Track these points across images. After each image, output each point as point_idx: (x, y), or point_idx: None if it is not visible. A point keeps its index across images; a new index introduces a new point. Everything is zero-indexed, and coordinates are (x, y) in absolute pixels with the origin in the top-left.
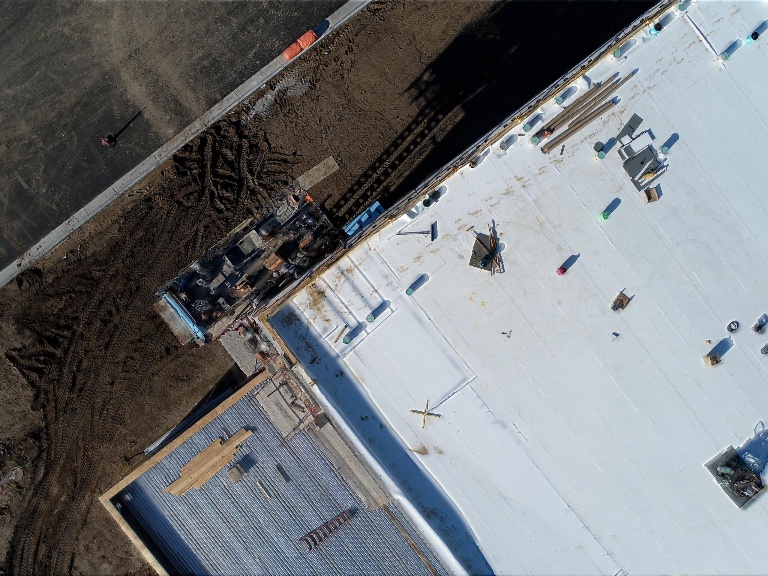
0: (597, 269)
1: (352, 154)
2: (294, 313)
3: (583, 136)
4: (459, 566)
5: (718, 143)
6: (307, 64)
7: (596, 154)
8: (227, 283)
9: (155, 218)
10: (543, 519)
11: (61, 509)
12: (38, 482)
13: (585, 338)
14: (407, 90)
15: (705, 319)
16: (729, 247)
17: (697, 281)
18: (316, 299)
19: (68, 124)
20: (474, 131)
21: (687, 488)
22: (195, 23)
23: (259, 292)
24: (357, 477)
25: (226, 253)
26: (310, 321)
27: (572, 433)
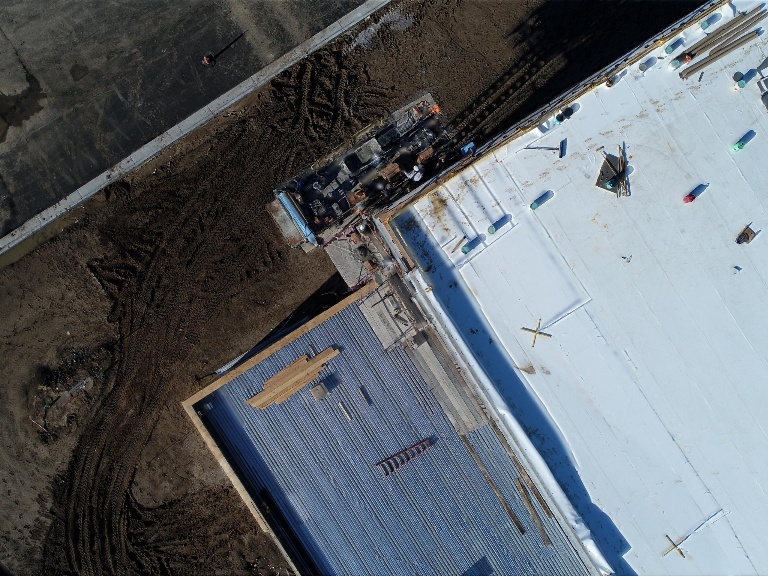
0: (725, 200)
1: (450, 93)
2: (414, 219)
3: (723, 65)
4: (559, 488)
5: None
6: None
7: (735, 83)
8: (340, 190)
9: (248, 141)
10: (646, 450)
11: (127, 423)
12: (107, 394)
13: (706, 270)
14: (511, 34)
15: None
16: None
17: None
18: (437, 207)
19: (170, 40)
20: (575, 80)
21: None
22: None
23: (369, 204)
24: (449, 400)
25: (344, 159)
26: (429, 229)
27: (684, 365)
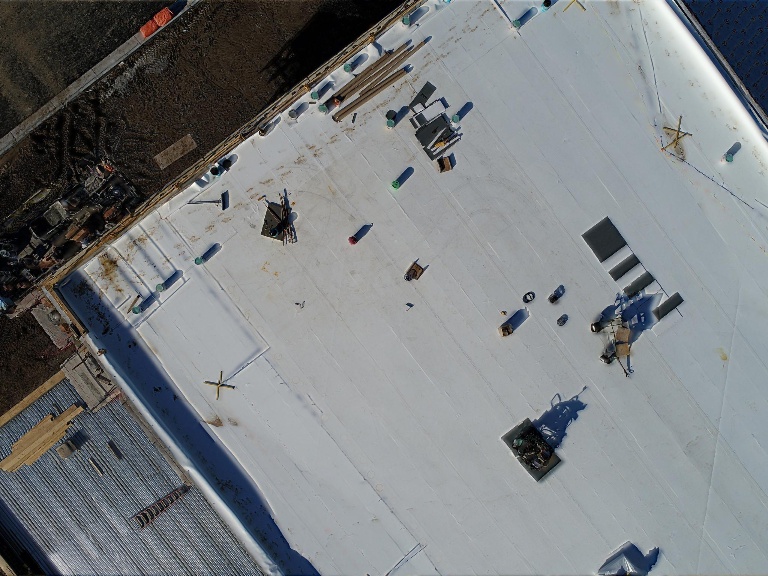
0: (390, 239)
1: (210, 132)
2: (86, 283)
3: (375, 104)
4: (250, 539)
5: (513, 112)
6: (166, 42)
7: (387, 122)
8: (35, 255)
9: (13, 196)
10: (339, 492)
11: None
12: None
13: (379, 309)
14: (265, 68)
15: (501, 290)
16: (525, 217)
17: (492, 251)
18: (108, 269)
19: None
20: None
21: (484, 461)
22: (53, 0)
23: None
24: None
25: (30, 224)
26: (102, 291)
27: (367, 405)
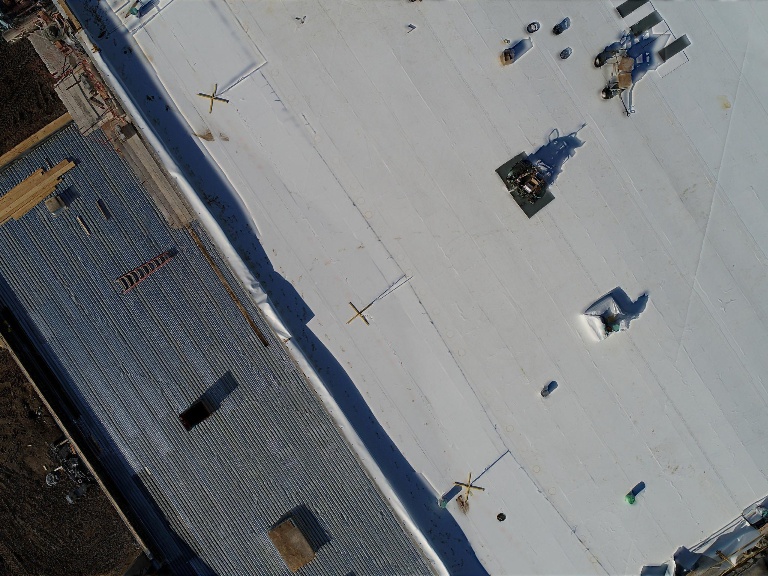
0: None
1: None
2: None
3: None
4: (234, 252)
5: None
6: None
7: None
8: None
9: None
10: (327, 216)
11: None
12: None
13: (381, 29)
14: None
15: (505, 18)
16: None
17: None
18: None
19: None
20: None
21: (476, 193)
22: None
23: None
24: (162, 193)
25: None
26: None
27: (362, 128)
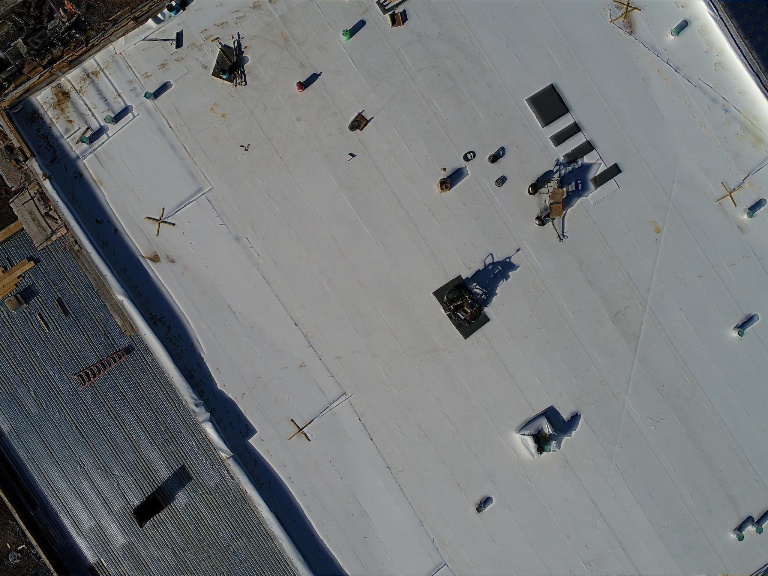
0: (337, 89)
1: None
2: (38, 111)
3: None
4: (178, 372)
5: None
6: None
7: None
8: None
9: None
10: (270, 336)
11: None
12: None
13: (322, 157)
14: None
15: (442, 147)
16: (471, 78)
17: (436, 109)
18: (60, 99)
19: None
20: None
21: (414, 315)
22: None
23: None
24: (115, 301)
25: None
26: (53, 121)
27: (304, 251)
